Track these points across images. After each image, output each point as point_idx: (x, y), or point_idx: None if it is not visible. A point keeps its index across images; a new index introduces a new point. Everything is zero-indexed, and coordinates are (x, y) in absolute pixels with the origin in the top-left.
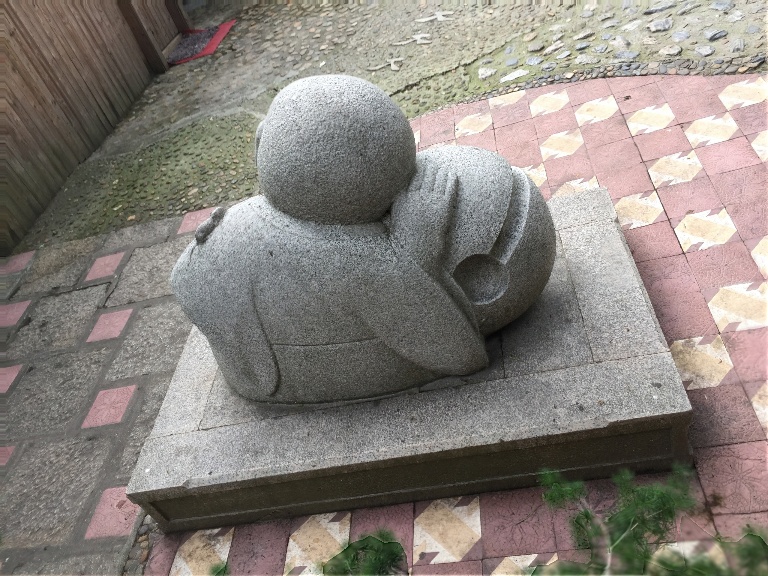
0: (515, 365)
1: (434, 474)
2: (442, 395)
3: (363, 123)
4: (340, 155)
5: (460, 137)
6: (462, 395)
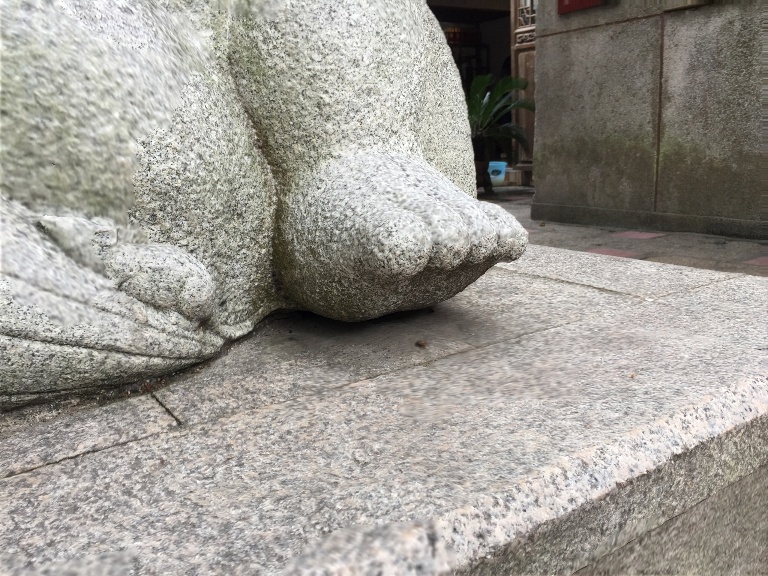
0: None
1: None
2: None
3: None
4: None
5: None
6: None
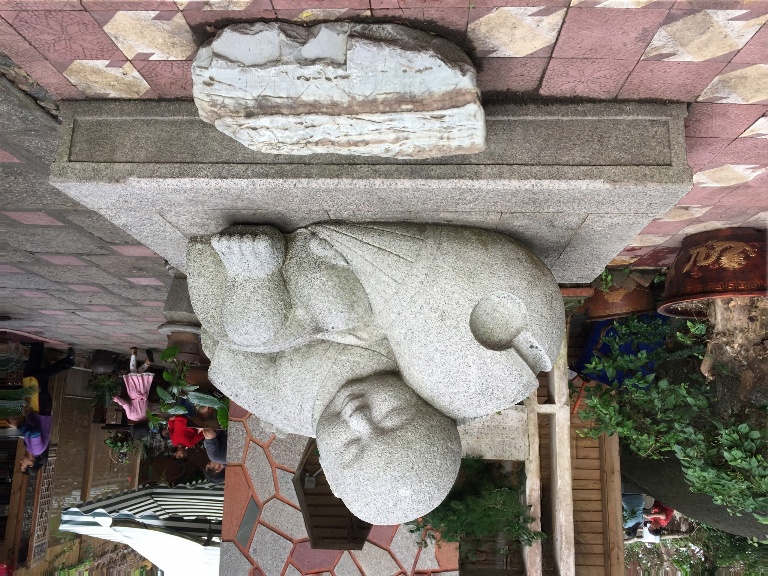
0: None
1: None
2: None
3: None
4: None
5: None
6: None
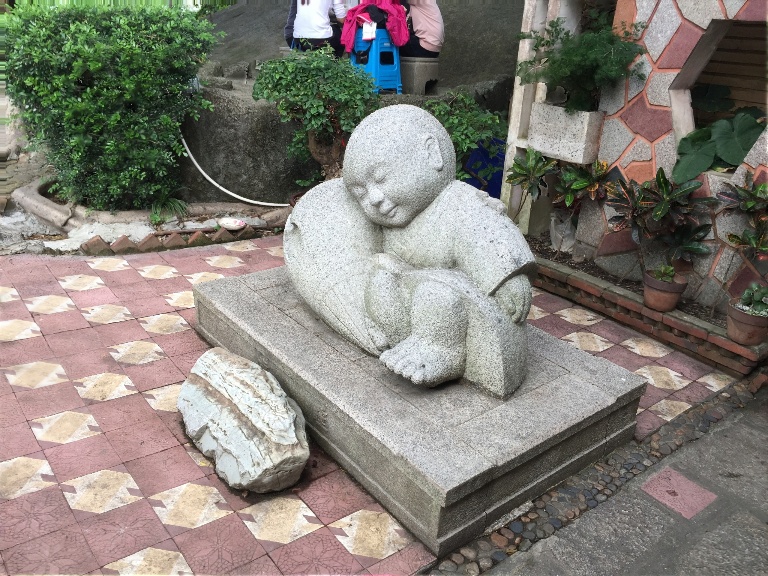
0: None
1: None
2: None
3: None
4: None
5: None
6: None
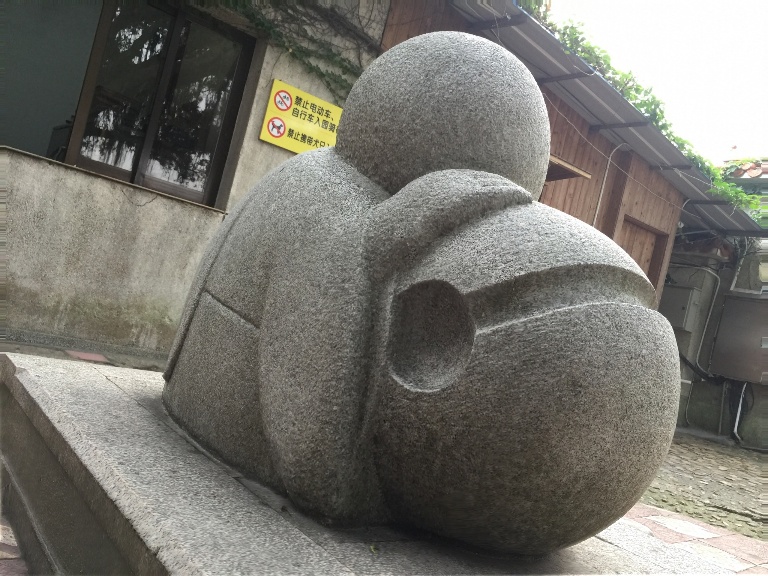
0: (357, 552)
1: (89, 571)
2: (238, 491)
3: (461, 54)
4: (406, 65)
5: (765, 567)
6: (249, 506)
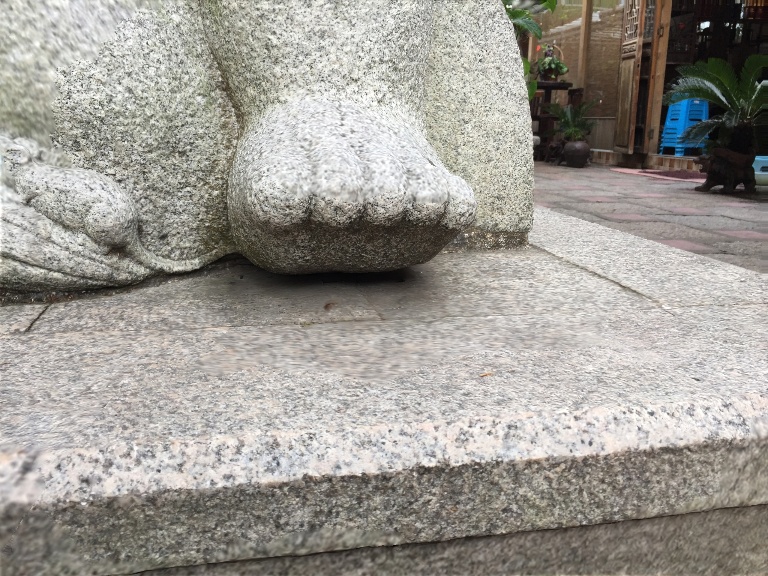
0: None
1: None
2: None
3: None
4: None
5: None
6: None
